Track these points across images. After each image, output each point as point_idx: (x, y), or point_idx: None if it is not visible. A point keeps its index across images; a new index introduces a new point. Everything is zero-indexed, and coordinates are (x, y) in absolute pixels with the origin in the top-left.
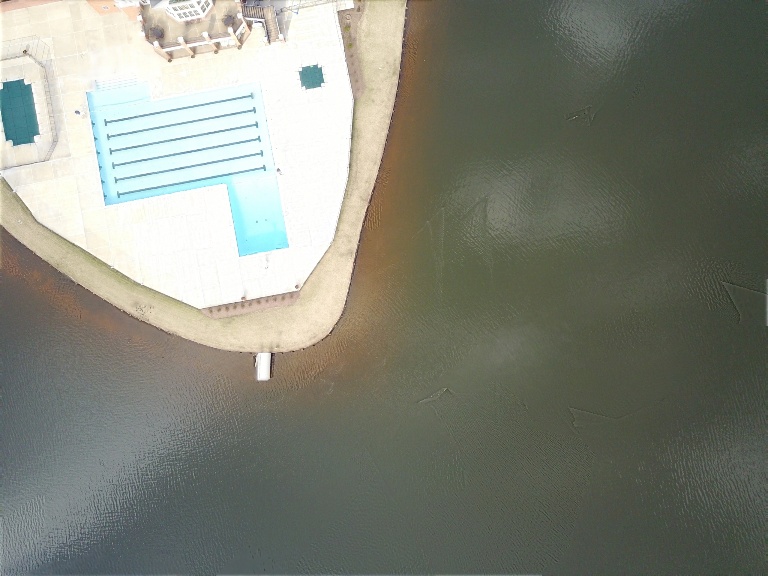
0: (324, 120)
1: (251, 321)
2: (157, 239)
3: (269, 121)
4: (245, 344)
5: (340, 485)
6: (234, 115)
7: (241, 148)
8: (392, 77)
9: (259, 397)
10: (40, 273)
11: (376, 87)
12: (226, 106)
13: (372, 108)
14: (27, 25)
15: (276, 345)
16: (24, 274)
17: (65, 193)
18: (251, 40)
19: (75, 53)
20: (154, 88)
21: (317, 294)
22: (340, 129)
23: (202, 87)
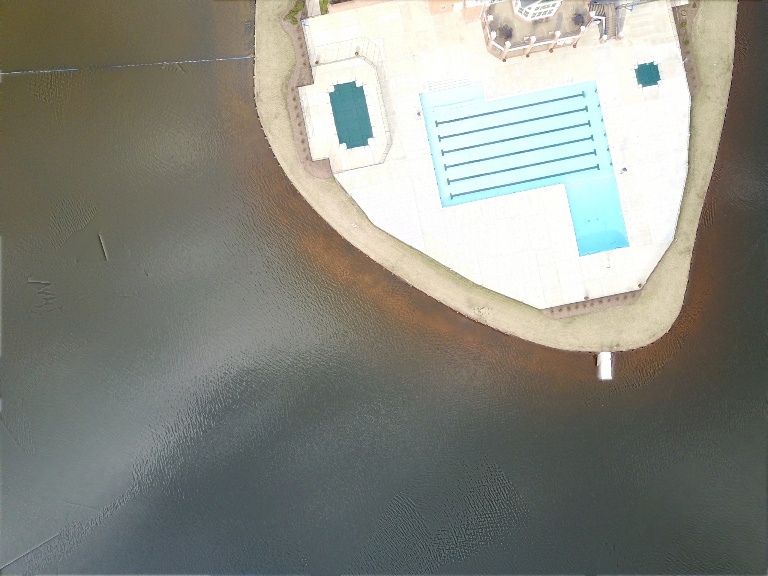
0: (661, 118)
1: (592, 320)
2: (495, 240)
3: (606, 120)
4: (585, 343)
5: (685, 481)
6: (566, 114)
7: (574, 147)
8: (726, 73)
9: (602, 396)
10: (372, 276)
11: (711, 84)
12: (558, 105)
13: (708, 105)
14: (356, 26)
15: (616, 344)
16: (355, 277)
17: (401, 196)
18: (585, 38)
19: (406, 54)
20: (488, 88)
21: (658, 292)
22: (677, 127)
23: (537, 86)
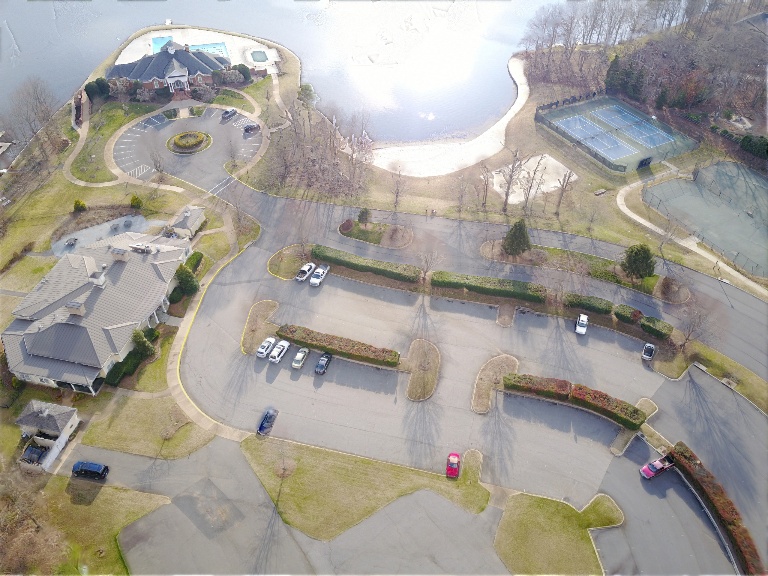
0: (129, 59)
1: None
2: None
3: None
4: None
5: (146, 8)
6: None
7: None
8: (96, 70)
9: None
10: None
11: None
12: None
13: None
14: None
15: None
16: None
17: None
18: None
19: None
20: None
21: None
22: None
23: None
